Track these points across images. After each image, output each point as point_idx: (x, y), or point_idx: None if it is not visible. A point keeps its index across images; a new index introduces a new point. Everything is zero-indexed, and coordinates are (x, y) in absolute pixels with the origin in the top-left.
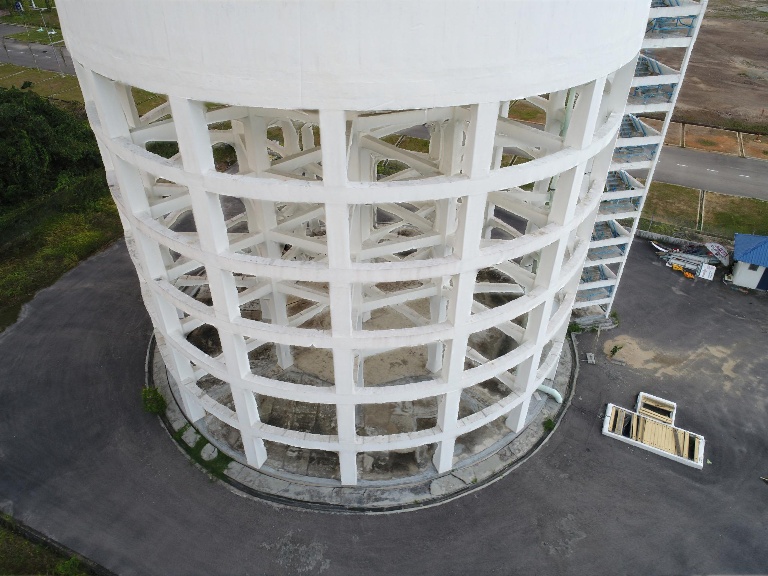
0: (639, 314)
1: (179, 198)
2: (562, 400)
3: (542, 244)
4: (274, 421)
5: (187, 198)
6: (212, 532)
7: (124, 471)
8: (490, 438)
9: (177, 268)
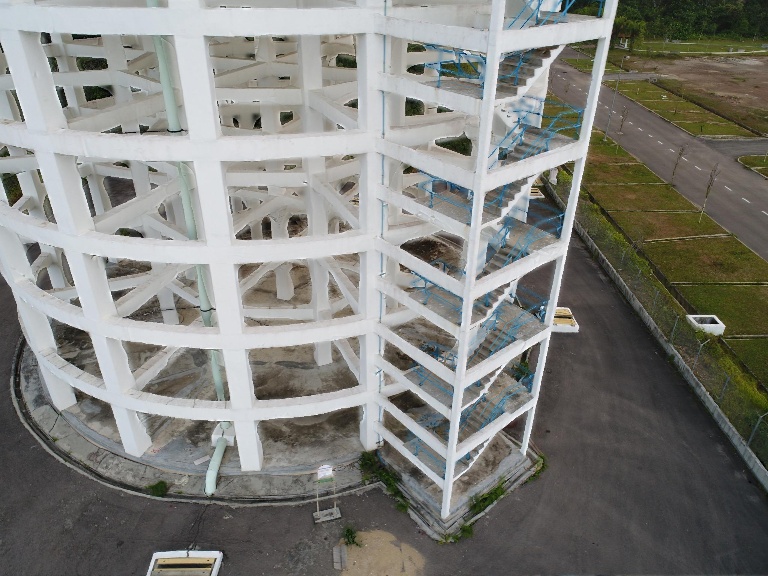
0: (507, 575)
1: (86, 46)
2: (212, 493)
3: (5, 138)
4: (117, 294)
5: (91, 49)
6: (1, 309)
7: (64, 259)
8: (113, 430)
9: (89, 110)
